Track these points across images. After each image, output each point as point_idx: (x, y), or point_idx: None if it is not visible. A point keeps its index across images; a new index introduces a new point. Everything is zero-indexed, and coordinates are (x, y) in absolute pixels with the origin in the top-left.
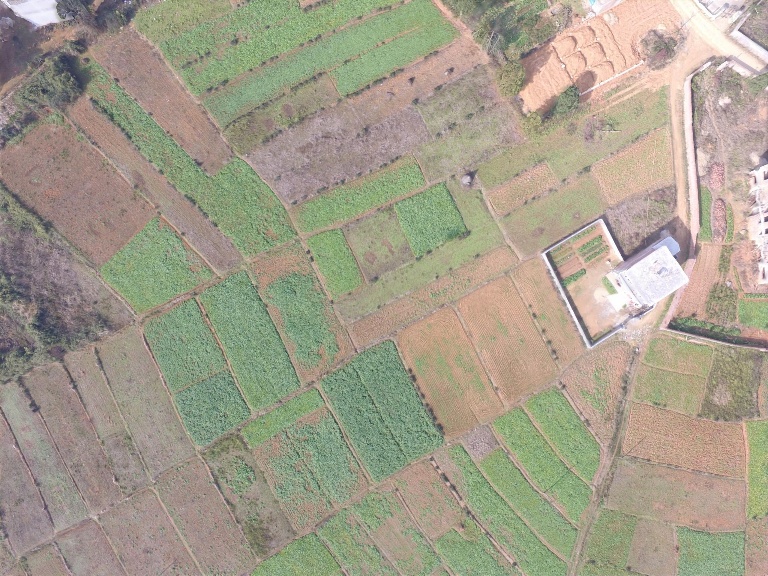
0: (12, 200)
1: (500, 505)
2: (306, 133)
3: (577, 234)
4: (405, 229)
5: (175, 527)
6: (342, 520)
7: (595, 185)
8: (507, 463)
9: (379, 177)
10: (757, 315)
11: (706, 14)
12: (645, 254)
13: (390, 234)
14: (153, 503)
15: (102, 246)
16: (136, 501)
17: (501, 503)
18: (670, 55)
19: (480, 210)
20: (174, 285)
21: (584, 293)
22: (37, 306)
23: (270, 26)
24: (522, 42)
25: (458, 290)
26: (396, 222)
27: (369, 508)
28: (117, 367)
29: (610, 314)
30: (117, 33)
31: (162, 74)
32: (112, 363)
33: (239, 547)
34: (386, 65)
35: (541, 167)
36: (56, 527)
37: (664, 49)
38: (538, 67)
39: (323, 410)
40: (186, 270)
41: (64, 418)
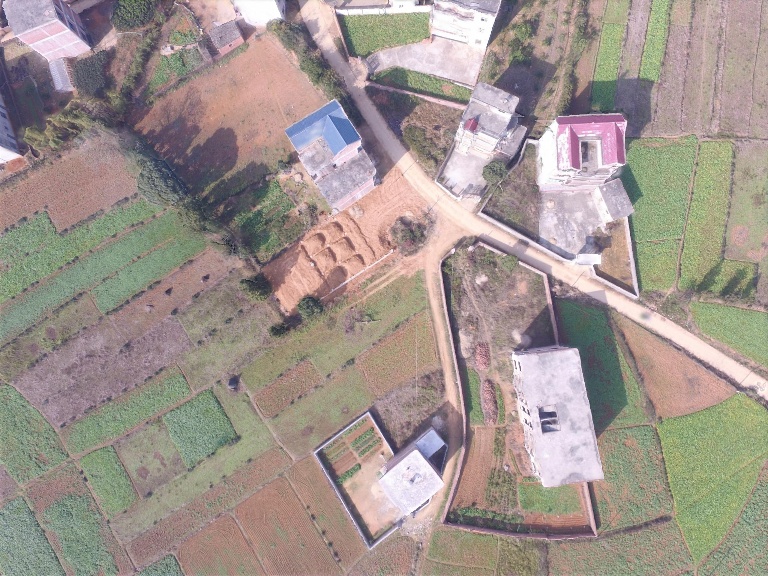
0: None
1: None
2: (71, 354)
3: (349, 428)
4: (174, 441)
5: None
6: None
7: (361, 377)
8: None
9: (145, 390)
10: (539, 499)
11: (451, 196)
12: (406, 453)
13: (161, 446)
14: None
15: None
16: None
17: None
18: (420, 240)
19: (248, 413)
20: None
21: (361, 489)
22: None
23: (29, 253)
24: (272, 244)
25: (233, 497)
26: (166, 434)
27: None
28: None
29: (389, 509)
30: None
31: None
32: None
33: None
34: (142, 279)
35: (304, 364)
36: None
37: (408, 239)
38: (288, 268)
39: None
40: None
41: None
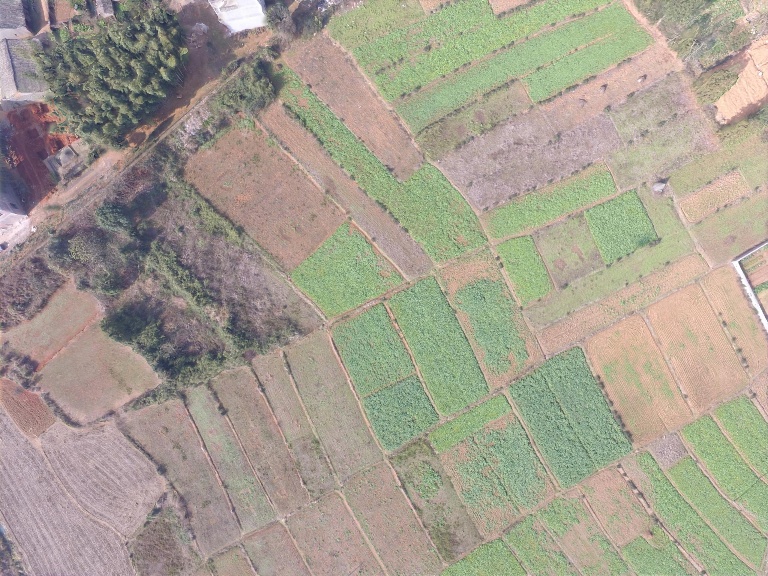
0: (205, 205)
1: (689, 513)
2: (498, 139)
3: None
4: (596, 236)
5: (361, 531)
6: (529, 526)
7: None
8: (696, 471)
9: (570, 184)
10: None
11: None
12: None
13: (580, 241)
14: (339, 506)
15: (293, 251)
16: (322, 504)
17: (690, 511)
18: None
19: (671, 217)
20: (365, 290)
21: None
22: (228, 310)
23: (463, 33)
24: (717, 49)
25: (648, 297)
26: (586, 229)
27: (556, 514)
28: (305, 371)
29: None
30: (310, 39)
31: (354, 80)
32: (300, 367)
33: (425, 551)
34: (579, 72)
35: (733, 175)
36: (244, 529)
37: None
38: None
39: (510, 416)
40: (376, 275)
41: (251, 421)
